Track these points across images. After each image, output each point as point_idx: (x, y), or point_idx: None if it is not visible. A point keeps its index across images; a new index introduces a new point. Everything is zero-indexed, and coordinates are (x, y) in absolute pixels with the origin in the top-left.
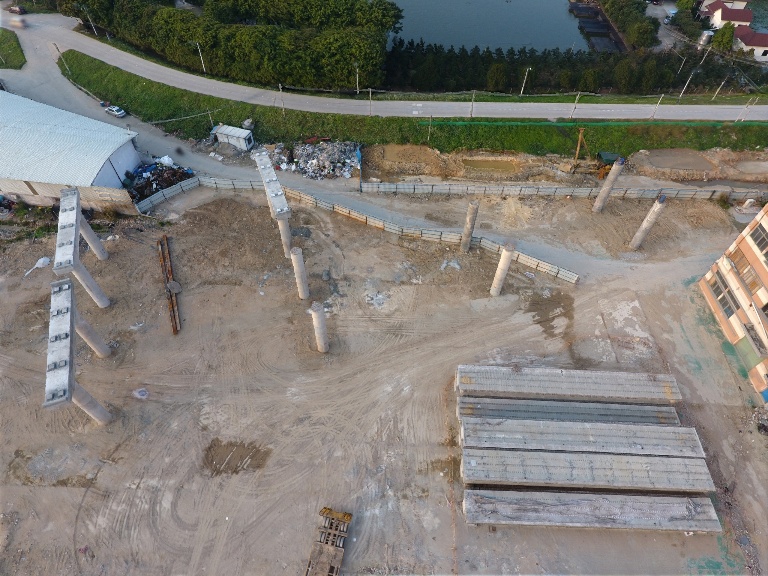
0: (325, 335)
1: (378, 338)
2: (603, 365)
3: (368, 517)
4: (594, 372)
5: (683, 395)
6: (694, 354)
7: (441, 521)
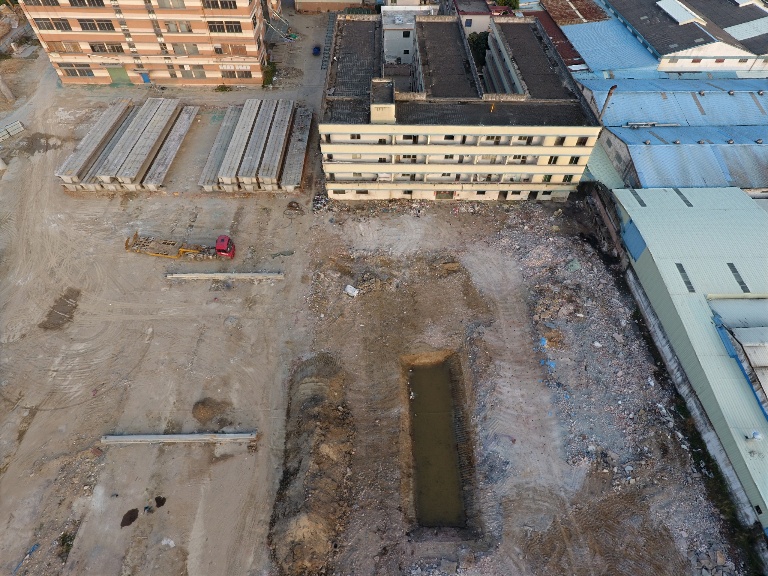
0: None
1: (1, 232)
2: None
3: (142, 232)
4: (97, 122)
5: None
6: (110, 97)
7: (158, 202)
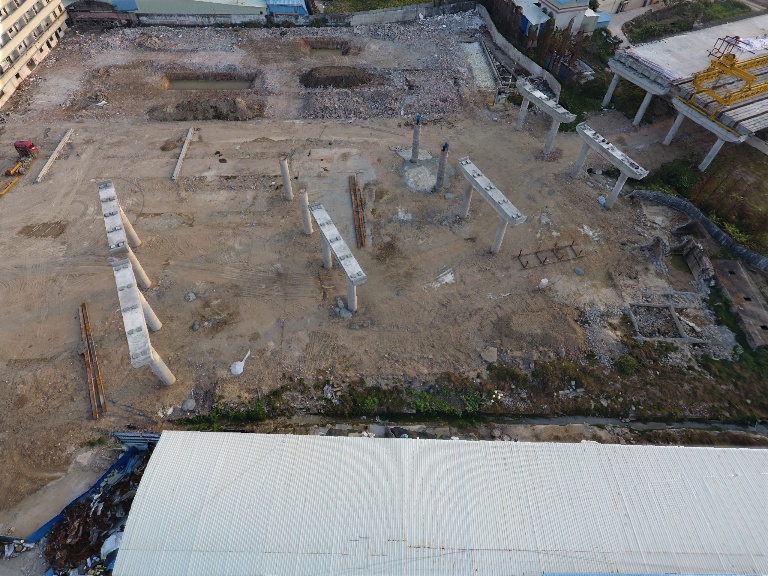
0: None
1: None
2: None
3: None
4: None
5: None
6: None
7: None
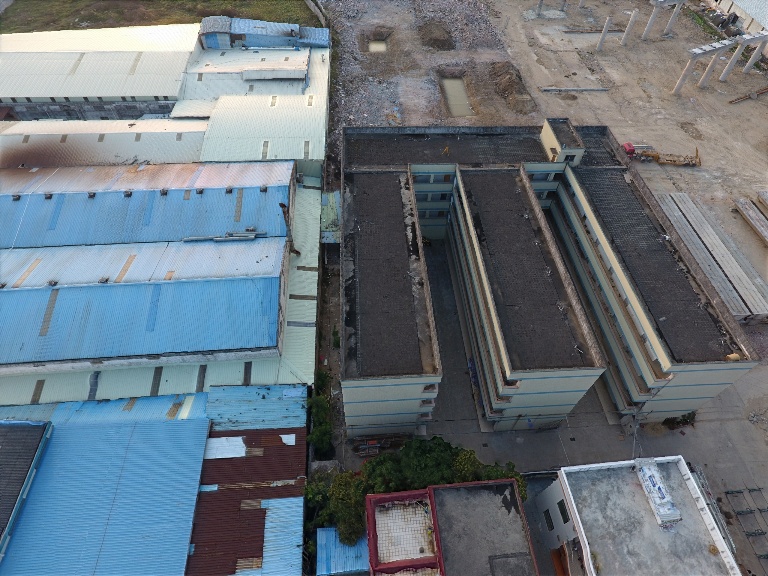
0: None
1: None
2: None
3: (703, 174)
4: None
5: None
6: None
7: None
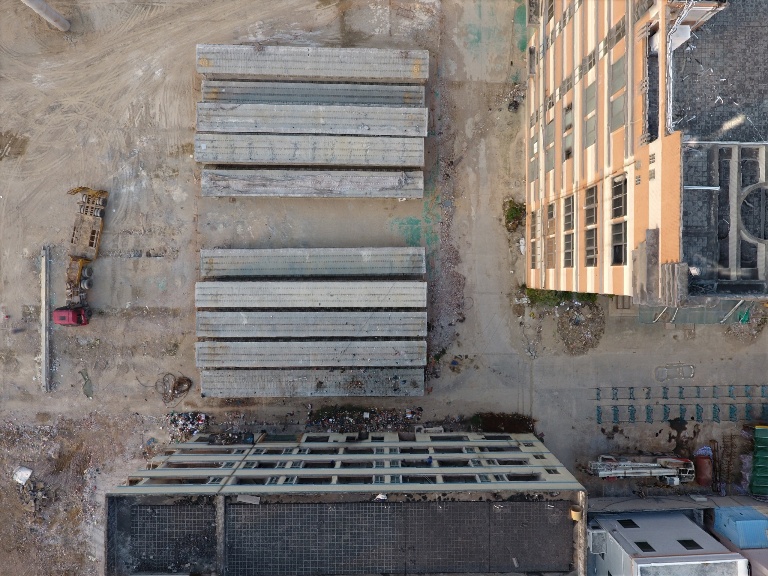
0: (45, 10)
1: (125, 11)
2: (373, 39)
3: (124, 193)
4: (343, 49)
5: (447, 72)
6: (479, 23)
7: (188, 195)
